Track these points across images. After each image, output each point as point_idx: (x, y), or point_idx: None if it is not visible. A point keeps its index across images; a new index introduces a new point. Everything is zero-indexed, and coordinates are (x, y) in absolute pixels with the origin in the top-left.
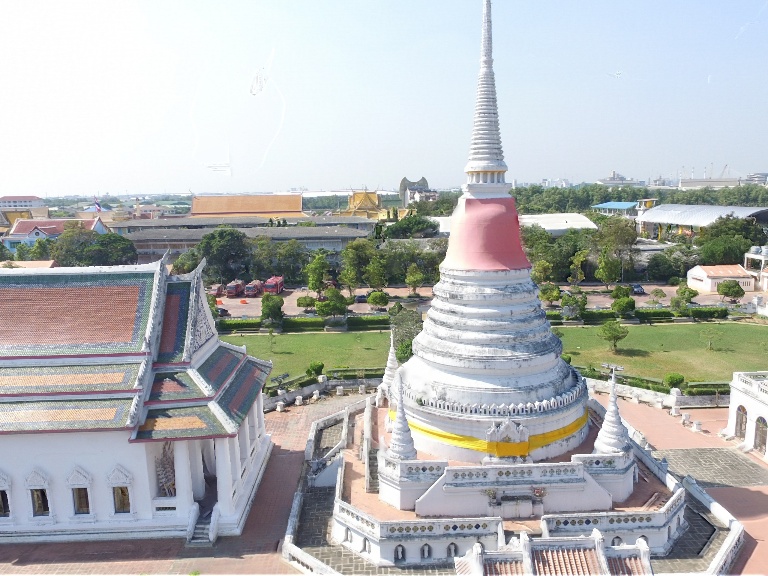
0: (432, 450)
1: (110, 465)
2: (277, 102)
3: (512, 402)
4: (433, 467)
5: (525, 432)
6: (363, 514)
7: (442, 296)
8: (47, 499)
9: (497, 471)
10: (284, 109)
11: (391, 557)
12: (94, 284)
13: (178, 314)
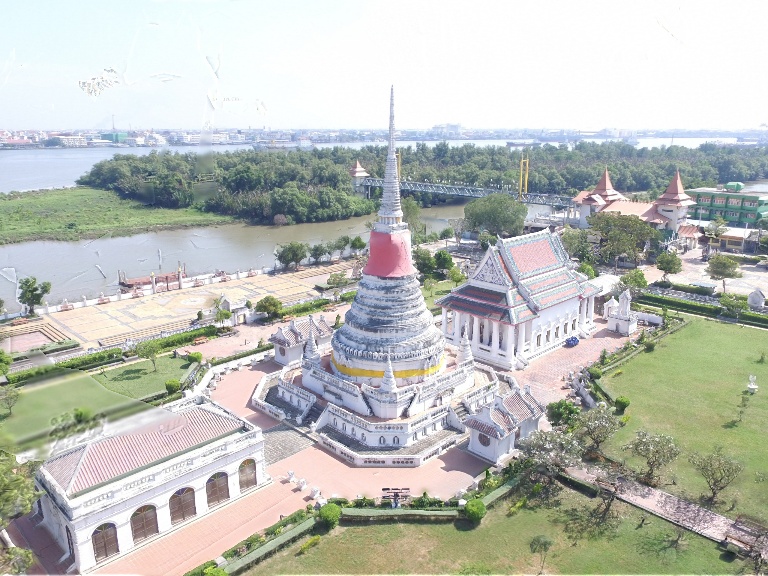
0: None
1: None
2: None
3: None
4: None
5: None
6: None
7: None
8: None
9: None
10: None
11: None
12: None
13: None
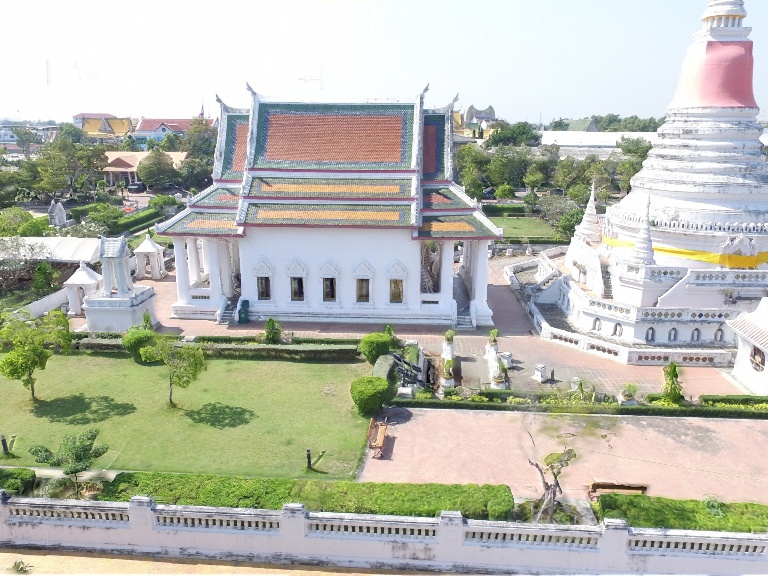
0: (662, 264)
1: (390, 260)
2: (367, 15)
3: (743, 222)
4: (673, 272)
5: (756, 247)
6: (618, 303)
7: (673, 133)
8: (335, 287)
9: (735, 274)
10: (374, 22)
11: (643, 337)
12: (362, 113)
13: (436, 142)
